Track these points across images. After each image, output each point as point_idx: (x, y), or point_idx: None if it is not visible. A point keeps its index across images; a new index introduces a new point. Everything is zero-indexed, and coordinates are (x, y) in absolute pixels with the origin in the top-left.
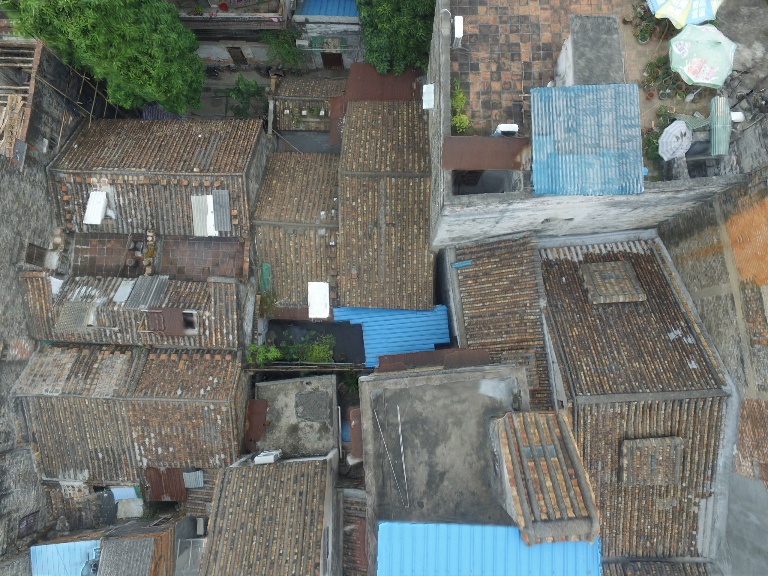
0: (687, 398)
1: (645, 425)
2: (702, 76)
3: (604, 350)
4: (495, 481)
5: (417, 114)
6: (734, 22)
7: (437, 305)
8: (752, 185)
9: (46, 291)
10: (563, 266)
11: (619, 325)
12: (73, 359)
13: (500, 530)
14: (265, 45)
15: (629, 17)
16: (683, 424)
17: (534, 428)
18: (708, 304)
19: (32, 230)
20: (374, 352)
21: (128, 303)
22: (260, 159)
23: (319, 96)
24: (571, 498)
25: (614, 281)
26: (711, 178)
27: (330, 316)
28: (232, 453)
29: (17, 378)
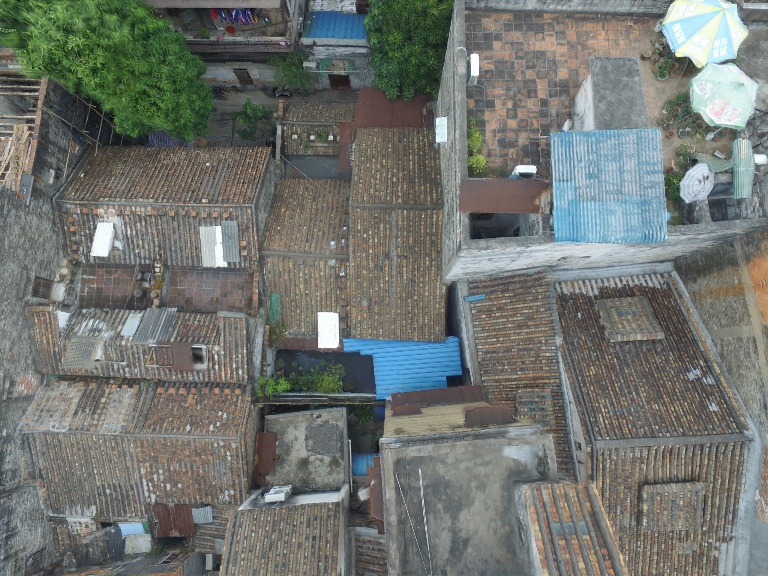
0: (708, 443)
1: (665, 469)
2: (724, 118)
3: (622, 391)
4: (521, 549)
5: (428, 142)
6: (754, 57)
7: (449, 337)
8: None
9: (53, 325)
10: (578, 301)
11: (637, 364)
12: (80, 393)
13: None
14: (272, 66)
15: (647, 53)
16: (704, 468)
17: (564, 502)
18: (728, 344)
19: (38, 263)
20: (385, 384)
21: (136, 337)
22: (269, 187)
23: (327, 121)
24: None
25: (631, 318)
26: (734, 222)
27: (340, 346)
28: (242, 489)
29: (23, 414)
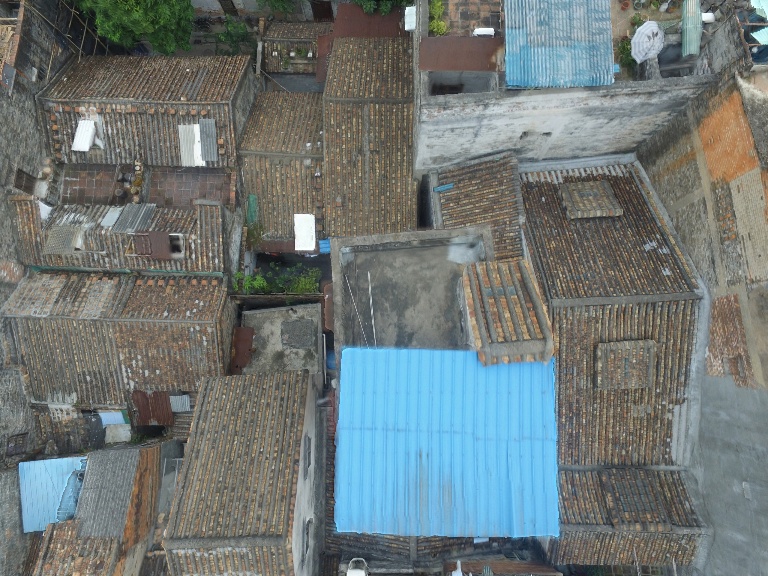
0: (660, 301)
1: (619, 329)
2: None
3: (580, 260)
4: (461, 339)
5: (402, 48)
6: None
7: None
8: (722, 84)
9: (35, 215)
10: (543, 188)
11: (596, 238)
12: (62, 284)
13: (459, 354)
14: None
15: None
16: (657, 329)
17: (496, 273)
18: (682, 214)
19: (21, 156)
20: None
21: (115, 227)
22: (247, 94)
23: (307, 37)
24: (528, 325)
25: (592, 198)
26: (682, 78)
27: (316, 249)
28: (218, 375)
29: (6, 300)
